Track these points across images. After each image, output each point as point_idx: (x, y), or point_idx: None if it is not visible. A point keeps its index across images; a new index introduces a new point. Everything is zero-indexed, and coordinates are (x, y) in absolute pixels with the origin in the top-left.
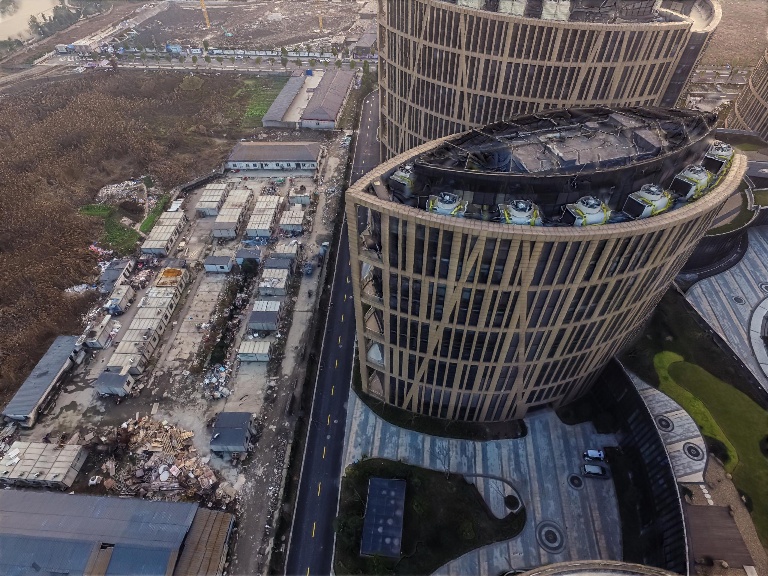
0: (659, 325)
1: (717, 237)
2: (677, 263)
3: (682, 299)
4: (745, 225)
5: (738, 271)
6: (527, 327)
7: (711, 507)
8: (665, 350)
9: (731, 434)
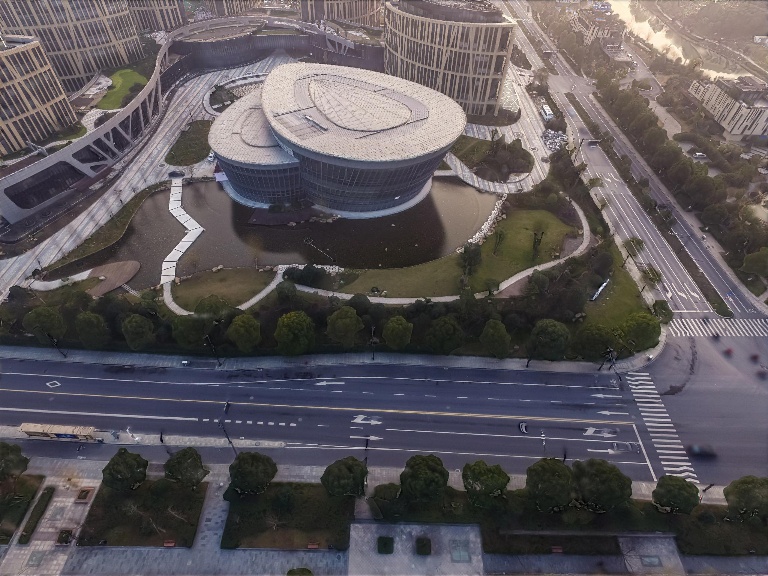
0: (134, 63)
1: (213, 43)
2: (78, 5)
3: (155, 56)
4: (232, 39)
5: (242, 68)
6: (7, 26)
7: (88, 98)
8: (127, 69)
9: (123, 85)
